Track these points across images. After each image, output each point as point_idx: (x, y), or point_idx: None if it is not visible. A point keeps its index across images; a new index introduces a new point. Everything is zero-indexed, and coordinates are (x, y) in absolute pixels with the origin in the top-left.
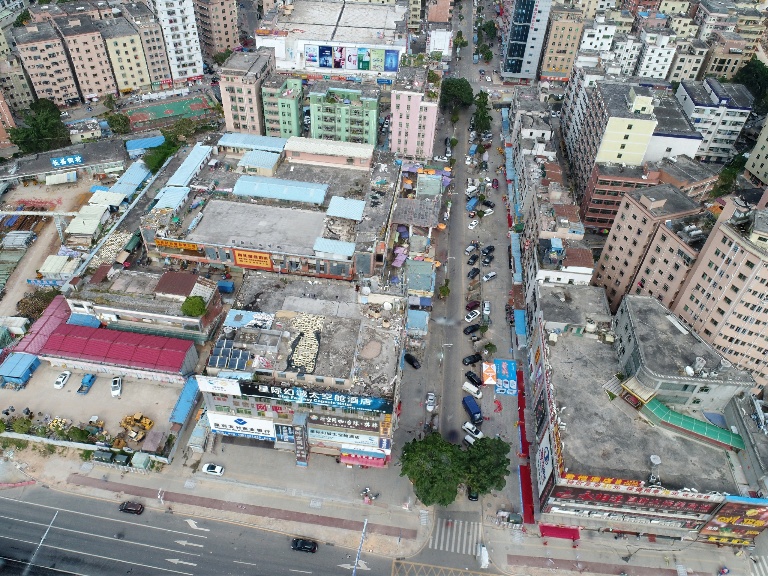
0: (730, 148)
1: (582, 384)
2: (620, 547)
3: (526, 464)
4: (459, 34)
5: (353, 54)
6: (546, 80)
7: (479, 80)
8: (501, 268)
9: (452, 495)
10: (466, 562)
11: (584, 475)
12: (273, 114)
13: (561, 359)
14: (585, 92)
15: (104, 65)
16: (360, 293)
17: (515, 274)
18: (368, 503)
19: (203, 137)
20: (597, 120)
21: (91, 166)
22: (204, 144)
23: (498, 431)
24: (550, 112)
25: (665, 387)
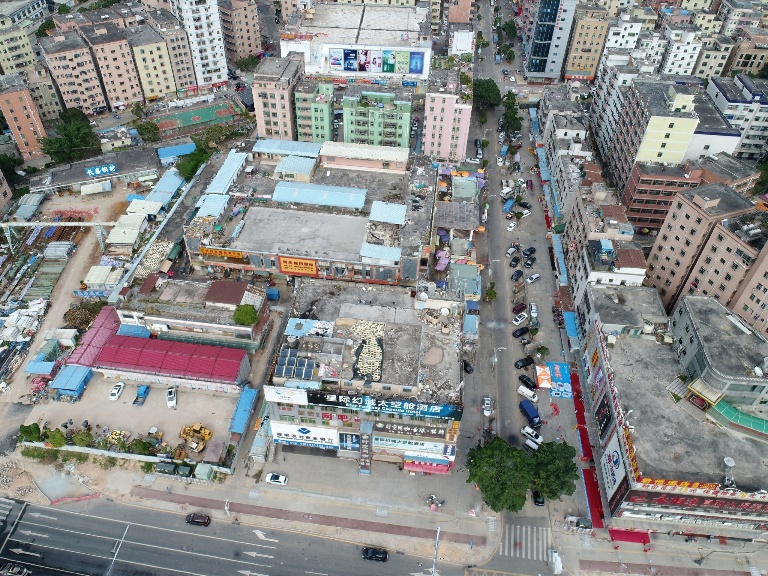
0: (763, 144)
1: (645, 386)
2: (691, 550)
3: (589, 468)
4: (479, 34)
5: (378, 57)
6: (577, 79)
7: (503, 80)
8: (544, 270)
9: (522, 501)
10: (538, 568)
11: (661, 479)
12: (306, 119)
13: (621, 361)
14: (619, 91)
15: (131, 73)
16: (417, 299)
17: (560, 276)
18: (434, 510)
19: (234, 143)
20: (635, 119)
21: (125, 175)
22: (239, 151)
23: (557, 435)
24: (583, 112)
25: (733, 388)
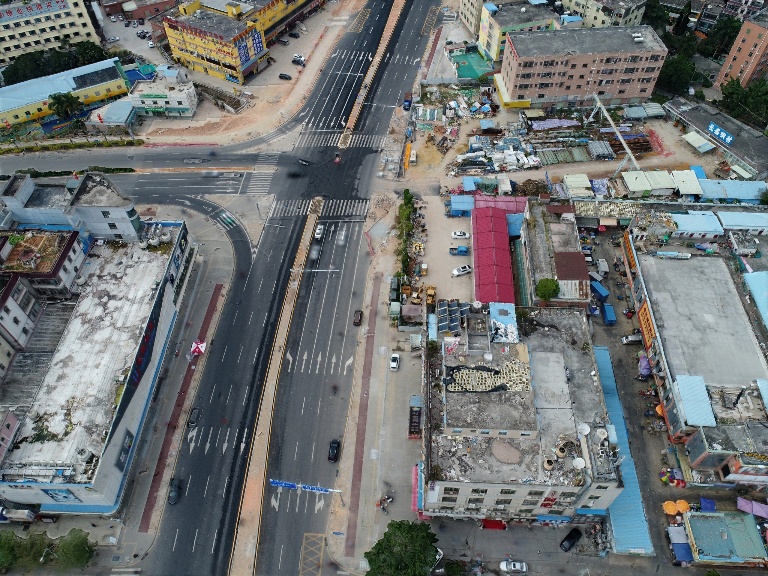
0: None
1: None
2: None
3: None
4: None
5: None
6: None
7: None
8: None
9: None
10: None
11: None
12: None
13: None
14: None
15: None
16: None
17: None
18: None
19: None
20: None
21: (731, 153)
22: None
23: None
24: None
25: None
